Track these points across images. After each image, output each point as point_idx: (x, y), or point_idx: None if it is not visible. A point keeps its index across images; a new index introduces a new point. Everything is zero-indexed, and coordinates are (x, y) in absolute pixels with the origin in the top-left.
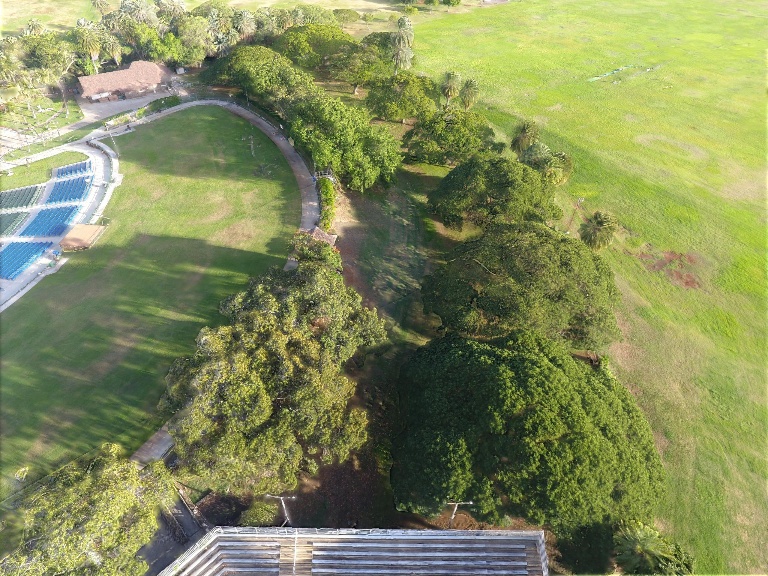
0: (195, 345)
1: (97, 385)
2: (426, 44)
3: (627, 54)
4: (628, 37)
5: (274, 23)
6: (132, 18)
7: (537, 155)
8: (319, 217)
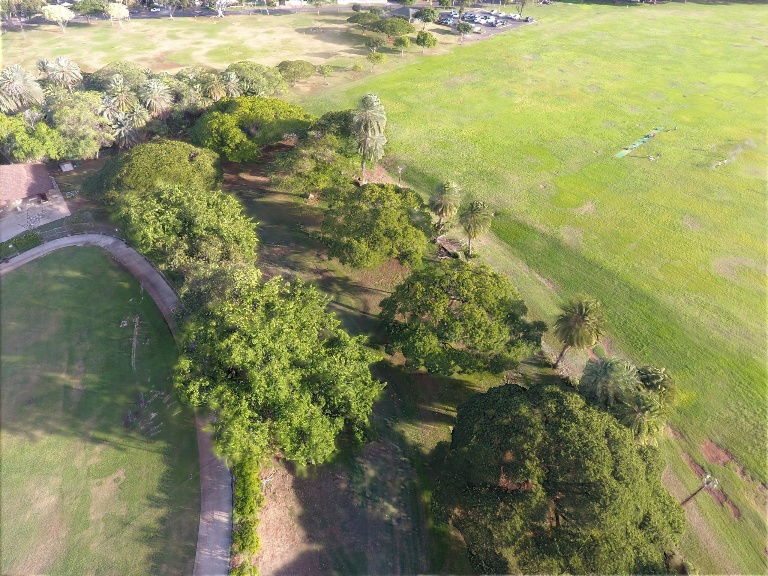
0: None
1: None
2: (400, 104)
3: (651, 109)
4: (644, 83)
5: (198, 92)
6: (2, 93)
7: (618, 385)
8: (228, 566)
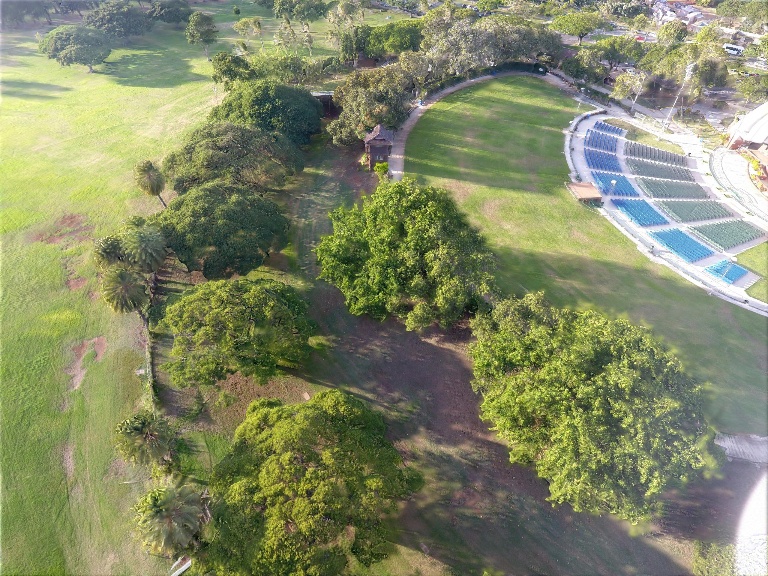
0: (431, 135)
1: (466, 126)
2: None
3: None
4: None
5: None
6: None
7: None
8: None
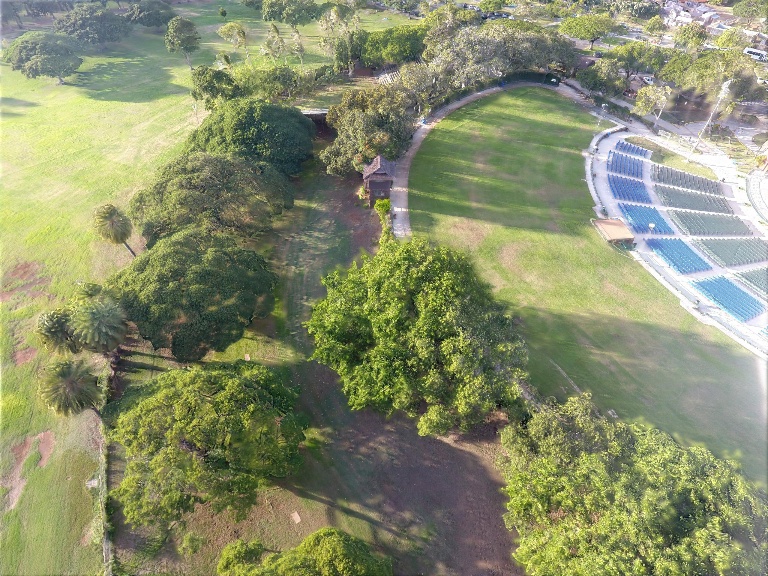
0: (437, 161)
1: (475, 149)
2: None
3: None
4: None
5: None
6: None
7: None
8: None
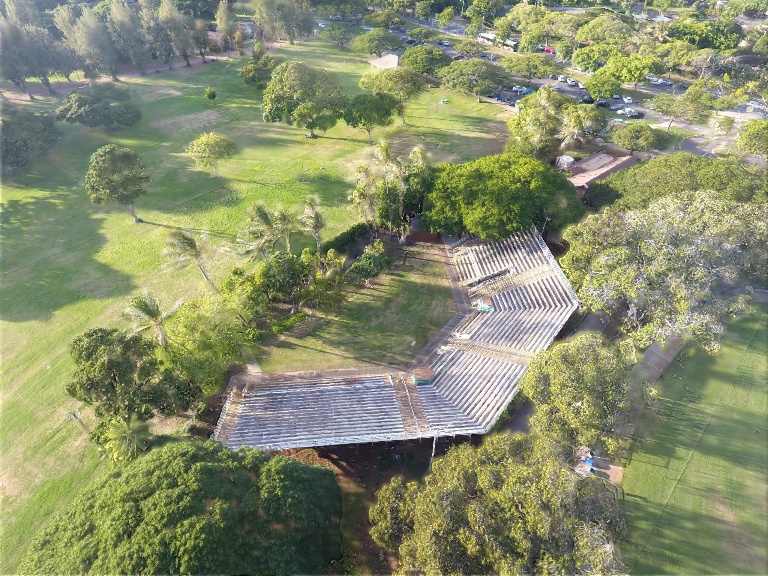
0: None
1: None
2: None
3: None
4: None
5: None
6: None
7: None
8: None
